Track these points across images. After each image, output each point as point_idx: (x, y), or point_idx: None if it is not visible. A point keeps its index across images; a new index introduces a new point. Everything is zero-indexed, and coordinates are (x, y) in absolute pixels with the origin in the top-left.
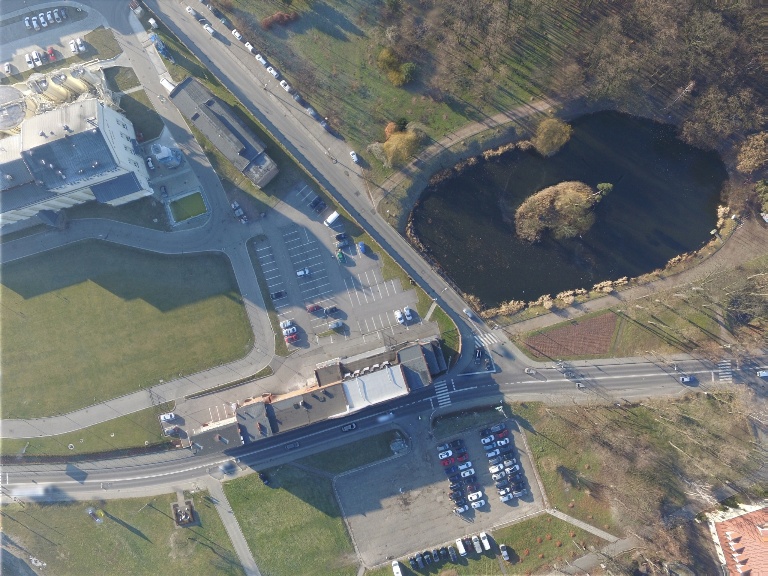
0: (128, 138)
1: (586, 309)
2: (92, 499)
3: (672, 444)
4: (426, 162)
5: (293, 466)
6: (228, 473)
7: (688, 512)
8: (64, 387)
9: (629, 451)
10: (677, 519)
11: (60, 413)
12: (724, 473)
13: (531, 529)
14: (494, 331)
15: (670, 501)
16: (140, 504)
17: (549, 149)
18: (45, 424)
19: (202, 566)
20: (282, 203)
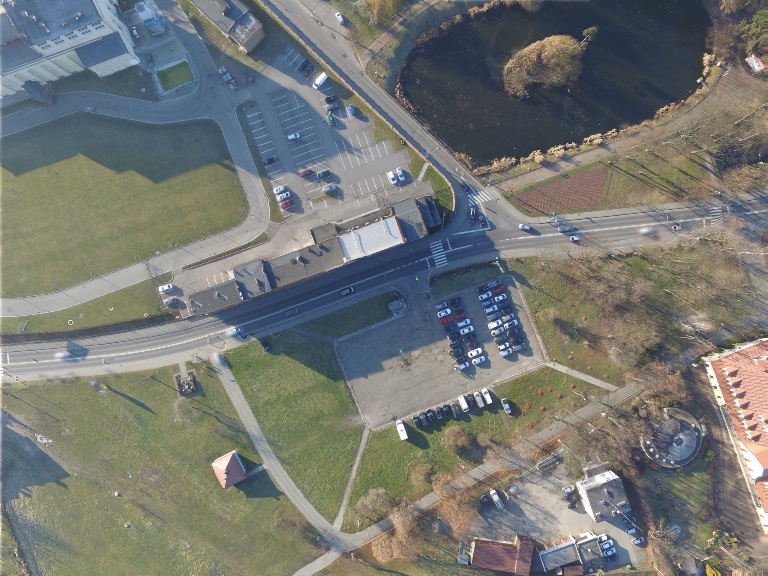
0: (111, 1)
1: (577, 162)
2: (94, 374)
3: (667, 290)
4: (412, 21)
5: (293, 332)
6: (229, 342)
7: (685, 358)
8: (60, 263)
9: (625, 300)
10: (674, 365)
11: (57, 289)
12: (719, 315)
13: (532, 383)
14: (487, 188)
15: (667, 348)
16: (143, 377)
17: (534, 1)
18: (43, 301)
19: (208, 435)
20: (270, 68)
